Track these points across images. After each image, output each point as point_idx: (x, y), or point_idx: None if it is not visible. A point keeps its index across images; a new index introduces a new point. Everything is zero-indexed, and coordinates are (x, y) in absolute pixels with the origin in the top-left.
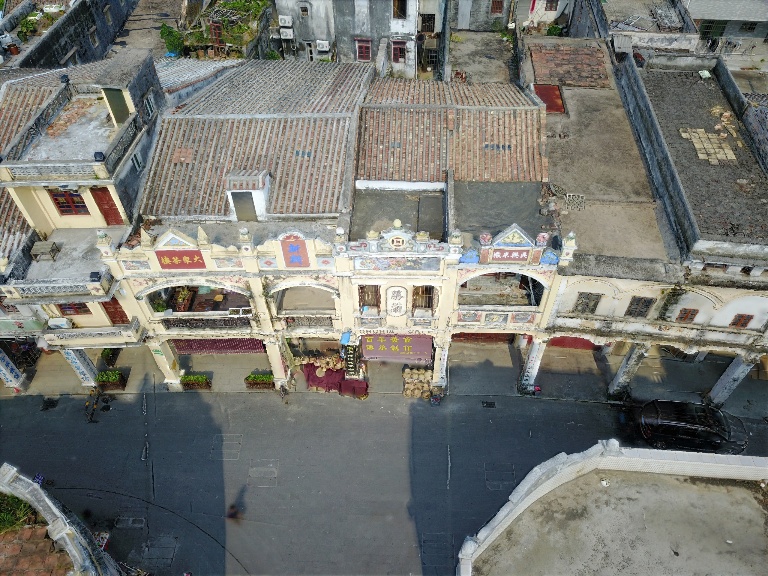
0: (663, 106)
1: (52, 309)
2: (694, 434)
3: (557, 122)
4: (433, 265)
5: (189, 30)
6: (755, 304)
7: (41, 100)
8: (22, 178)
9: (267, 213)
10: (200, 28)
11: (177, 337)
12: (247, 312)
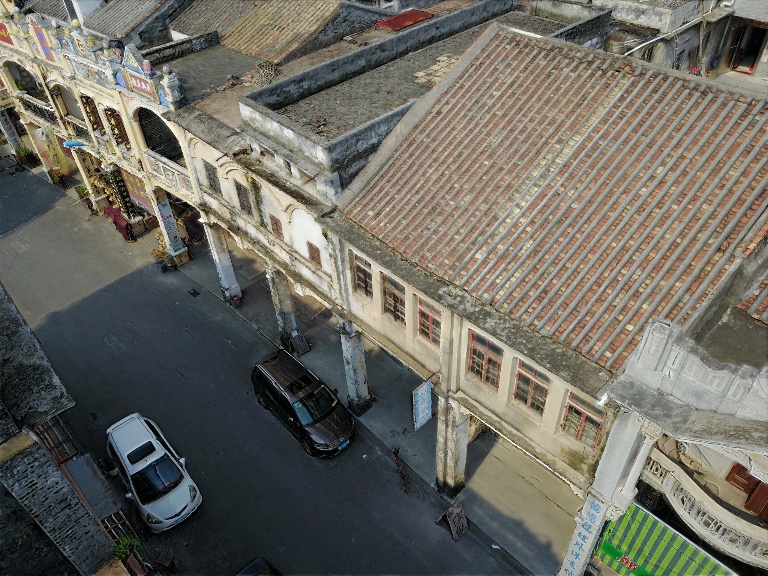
0: (476, 38)
1: None
2: (278, 397)
3: (380, 37)
4: None
5: None
6: (311, 227)
7: None
8: None
9: None
10: None
11: None
12: None
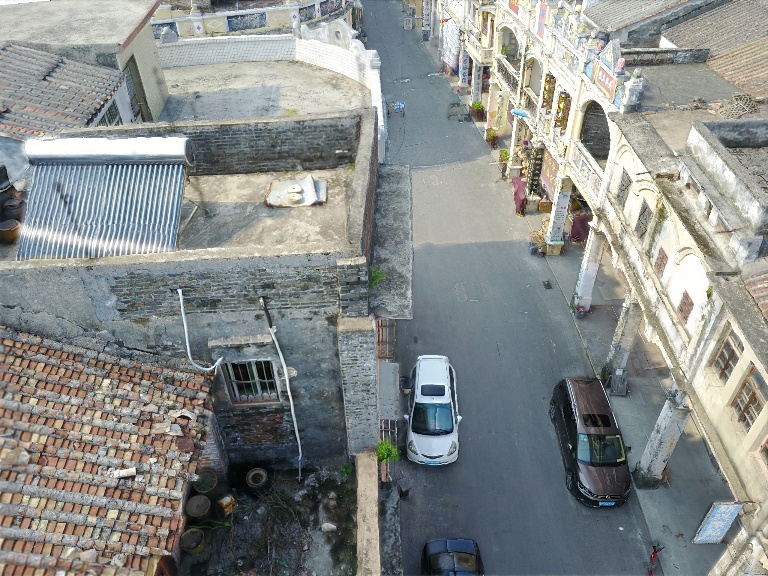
0: None
1: None
2: (569, 419)
3: None
4: None
5: None
6: None
7: None
8: None
9: None
10: None
11: None
12: None
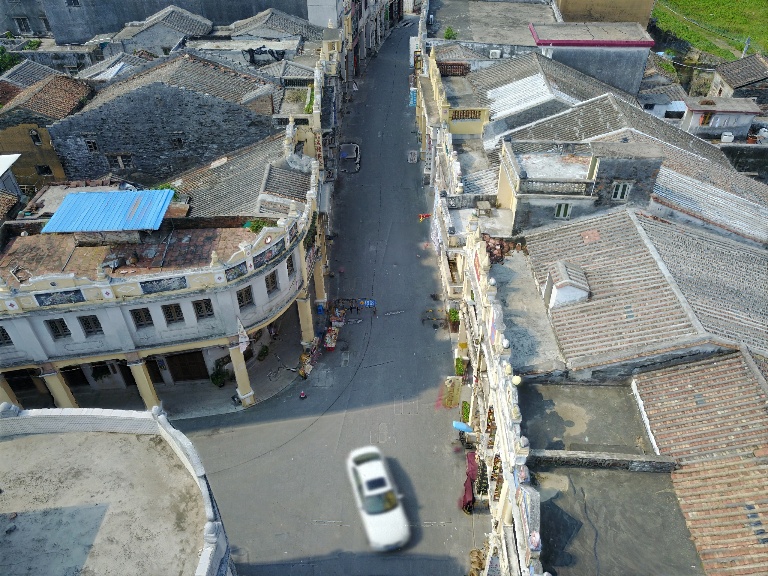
0: None
1: None
2: None
3: None
4: None
5: None
6: None
7: None
8: None
9: None
10: None
11: None
12: None
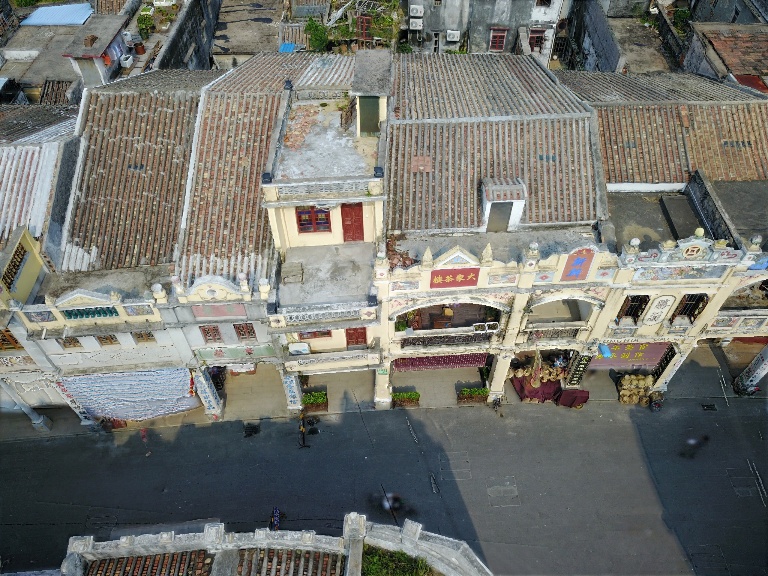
0: None
1: (293, 334)
2: None
3: None
4: (716, 273)
5: (334, 24)
6: None
7: (246, 107)
8: (288, 197)
9: (520, 223)
10: (346, 21)
11: (409, 355)
12: (493, 327)
